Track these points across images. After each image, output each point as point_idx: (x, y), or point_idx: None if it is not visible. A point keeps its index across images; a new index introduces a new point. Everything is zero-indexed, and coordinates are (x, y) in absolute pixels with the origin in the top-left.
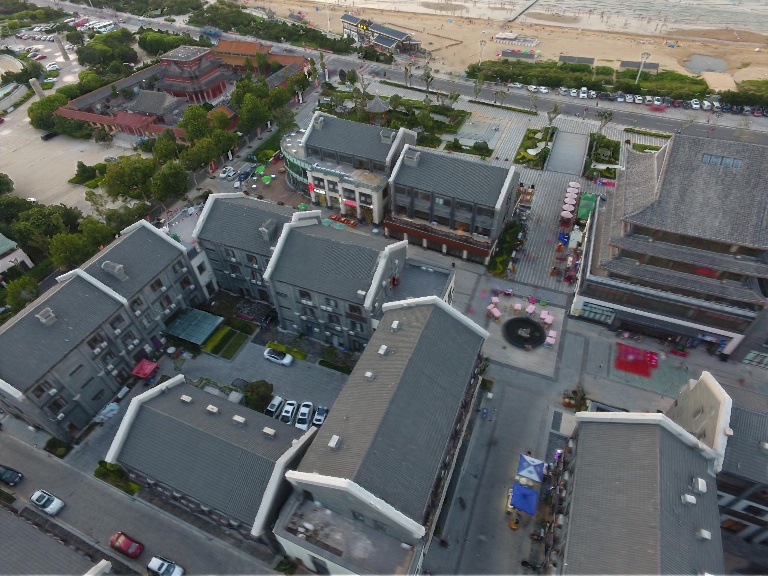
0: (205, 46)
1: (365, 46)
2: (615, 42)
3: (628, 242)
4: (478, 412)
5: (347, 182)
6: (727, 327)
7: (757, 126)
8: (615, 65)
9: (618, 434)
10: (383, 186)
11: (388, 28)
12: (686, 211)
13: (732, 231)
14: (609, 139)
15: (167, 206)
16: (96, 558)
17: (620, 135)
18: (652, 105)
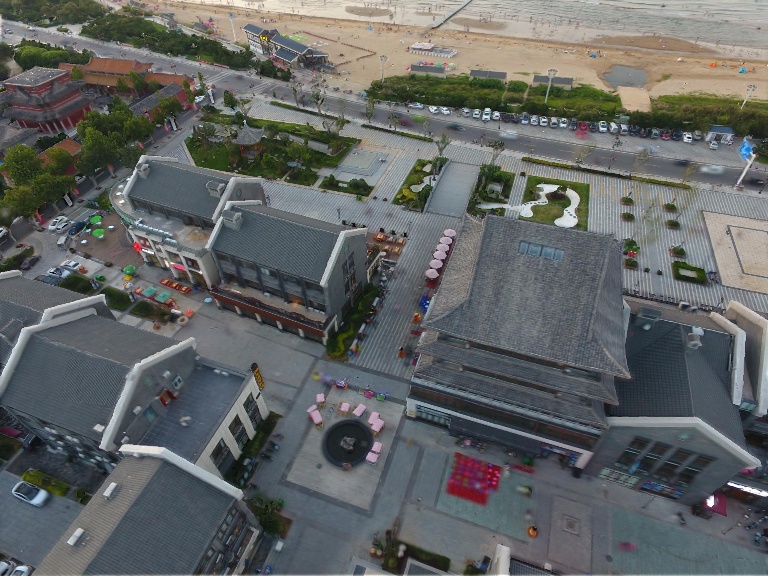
0: (87, 62)
1: None
2: (536, 52)
3: (442, 348)
4: (257, 574)
5: (169, 244)
6: (574, 441)
7: (664, 152)
8: (530, 79)
9: None
10: None
11: (290, 40)
12: (500, 315)
13: (552, 344)
14: (500, 173)
15: None
16: None
17: (517, 165)
18: (558, 128)
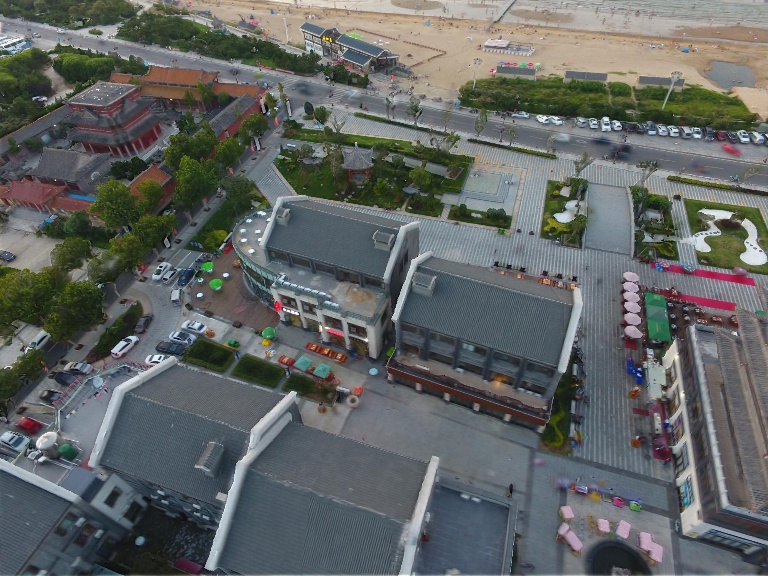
0: (136, 70)
1: (333, 64)
2: (621, 47)
3: None
4: None
5: (329, 308)
6: None
7: None
8: (629, 79)
9: None
10: (381, 313)
11: (359, 41)
12: None
13: None
14: (657, 197)
15: (77, 336)
16: None
17: (664, 186)
18: (691, 139)
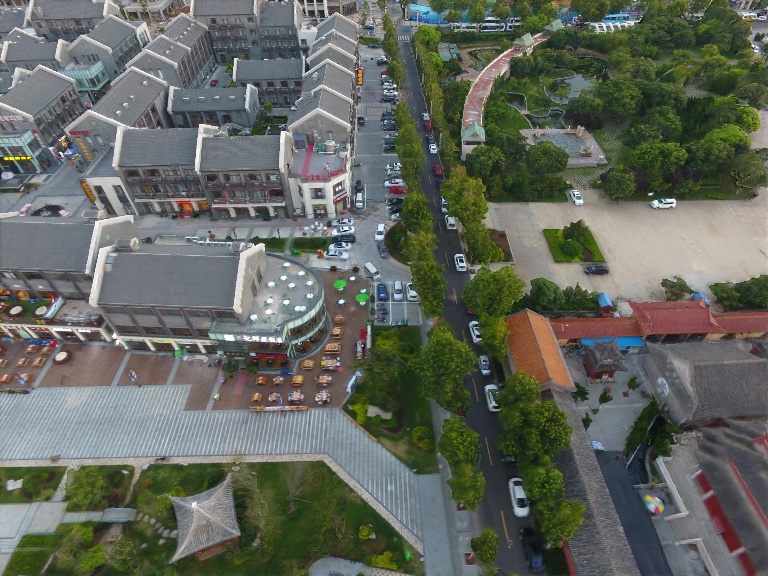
0: None
1: None
2: None
3: None
4: None
5: None
6: None
7: None
8: None
9: (16, 108)
10: None
11: None
12: None
13: None
14: None
15: None
16: None
17: None
18: None
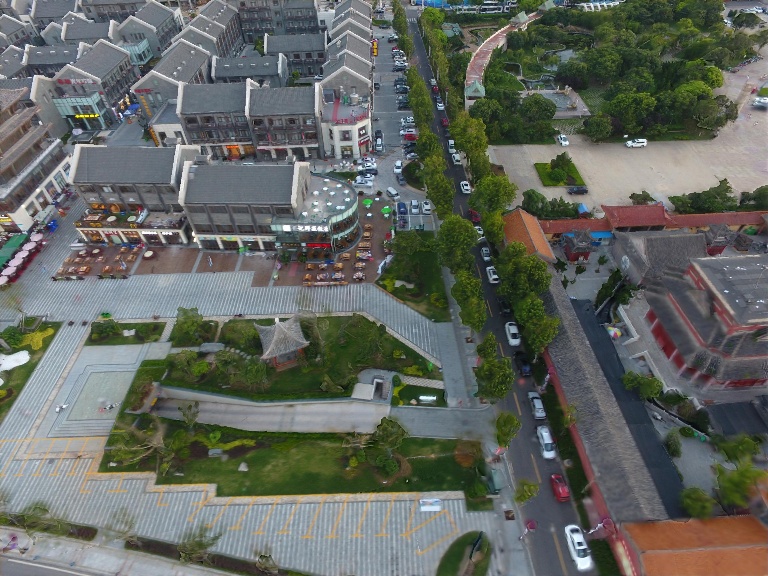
0: None
1: None
2: None
3: None
4: None
5: None
6: None
7: None
8: None
9: None
10: None
11: None
12: None
13: None
14: None
15: None
16: None
17: None
18: None
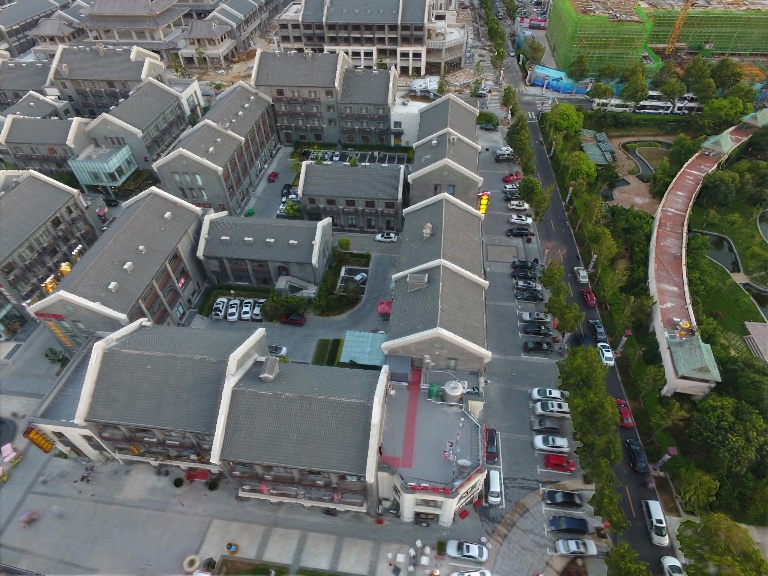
0: None
1: None
2: None
3: None
4: None
5: None
6: None
7: None
8: None
9: None
10: None
11: None
12: None
13: None
14: None
15: None
16: (337, 230)
17: None
18: None
